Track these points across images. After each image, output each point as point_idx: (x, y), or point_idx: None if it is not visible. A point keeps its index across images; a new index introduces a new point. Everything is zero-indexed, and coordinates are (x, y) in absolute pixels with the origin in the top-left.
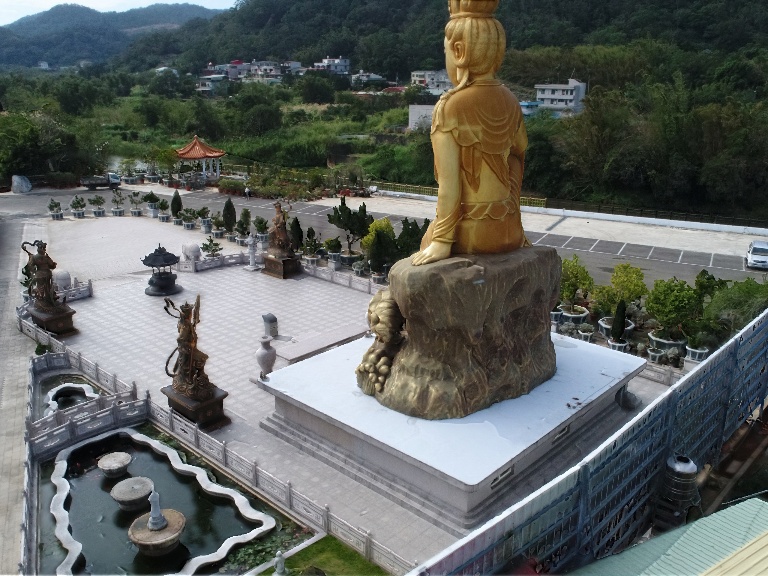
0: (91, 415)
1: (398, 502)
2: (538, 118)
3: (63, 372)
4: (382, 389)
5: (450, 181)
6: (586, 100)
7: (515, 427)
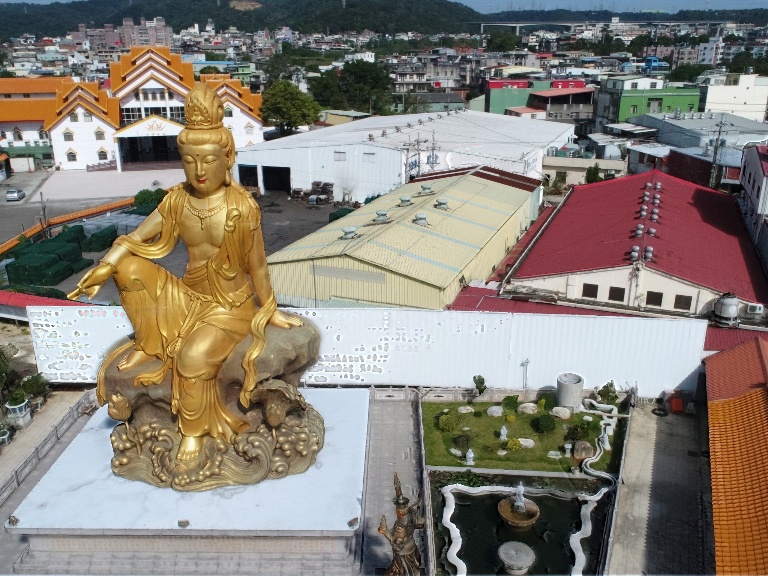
0: None
1: None
2: None
3: None
4: (319, 438)
5: None
6: None
7: None
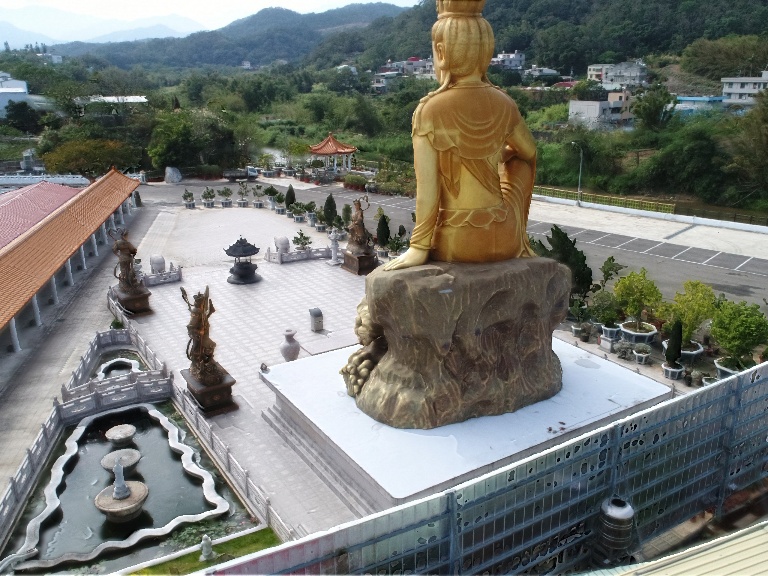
0: (116, 388)
1: (348, 505)
2: (702, 115)
3: (123, 347)
4: (359, 392)
5: (426, 186)
6: (758, 95)
7: (478, 445)
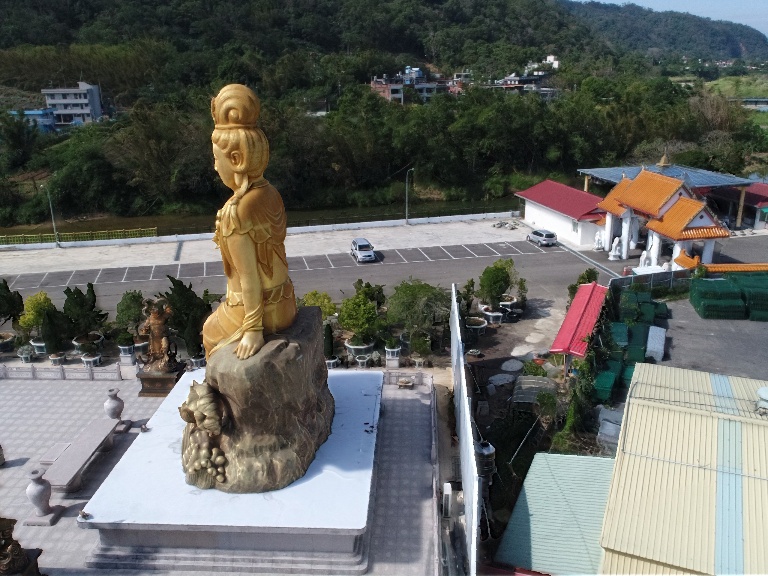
0: None
1: (287, 572)
2: (85, 135)
3: None
4: (225, 479)
5: (254, 276)
6: (134, 114)
7: (348, 466)
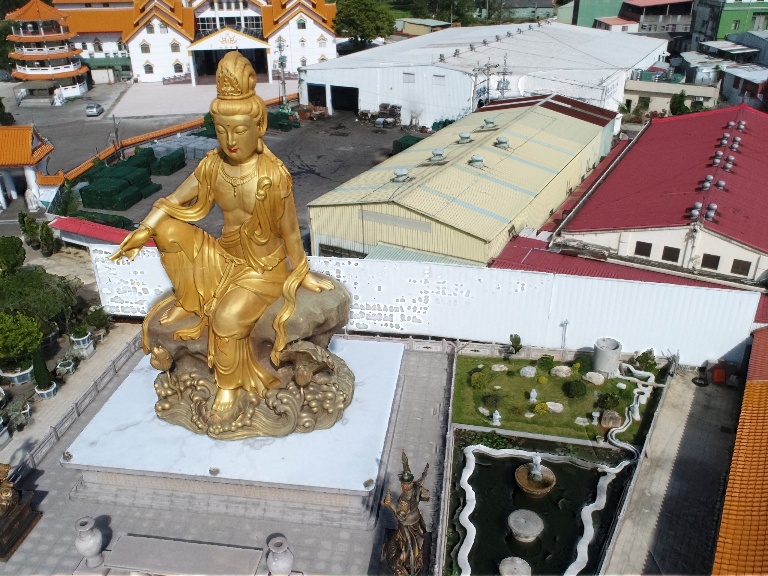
0: None
1: None
2: None
3: None
4: None
5: None
6: None
7: None
